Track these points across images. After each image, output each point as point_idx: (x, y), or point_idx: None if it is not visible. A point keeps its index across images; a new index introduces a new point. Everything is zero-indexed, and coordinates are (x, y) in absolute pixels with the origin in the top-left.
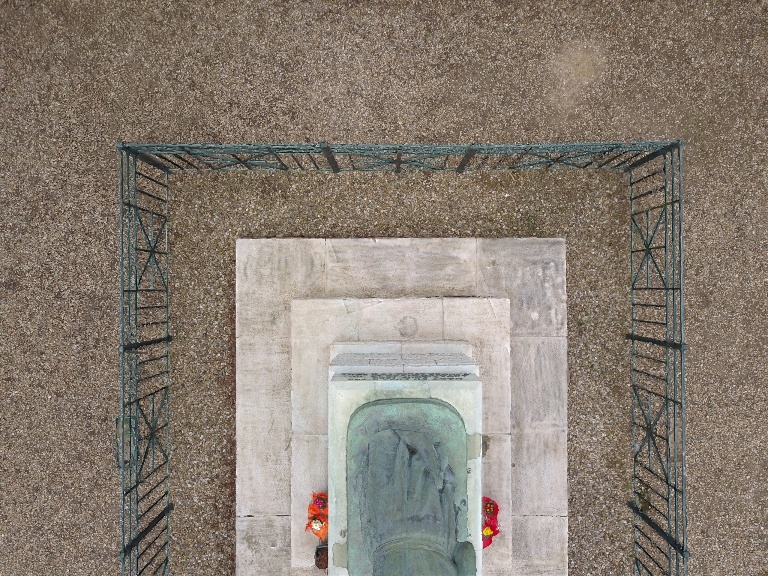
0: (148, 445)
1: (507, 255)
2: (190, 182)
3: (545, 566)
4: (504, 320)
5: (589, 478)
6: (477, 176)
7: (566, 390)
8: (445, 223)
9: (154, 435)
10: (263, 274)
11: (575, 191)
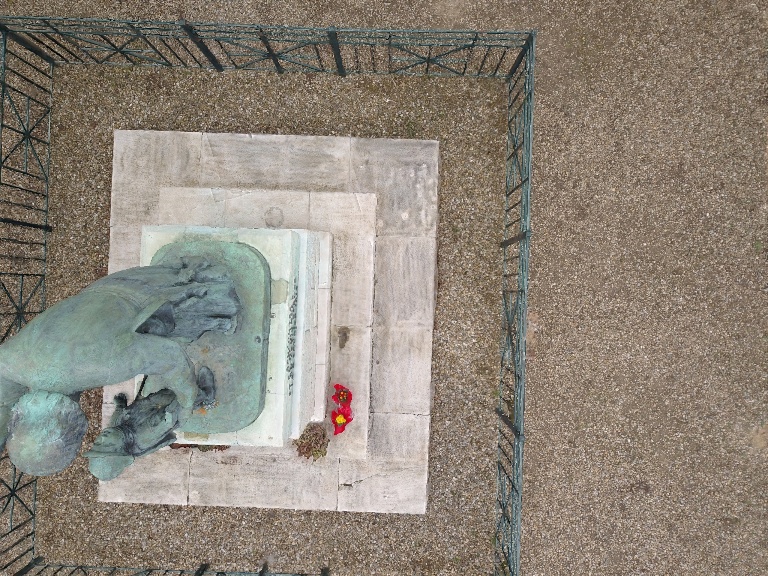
0: (12, 323)
1: (380, 155)
2: (76, 76)
3: (405, 463)
4: (369, 214)
5: (458, 383)
6: (360, 81)
7: (433, 290)
8: (326, 125)
9: (21, 316)
10: (139, 165)
11: (456, 99)
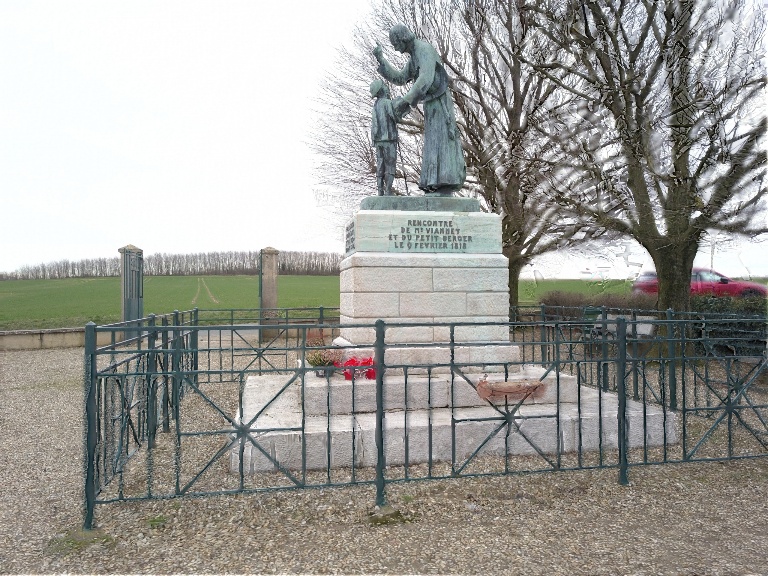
0: None
1: None
2: None
3: None
4: None
5: None
6: None
7: None
8: None
9: None
10: None
11: None
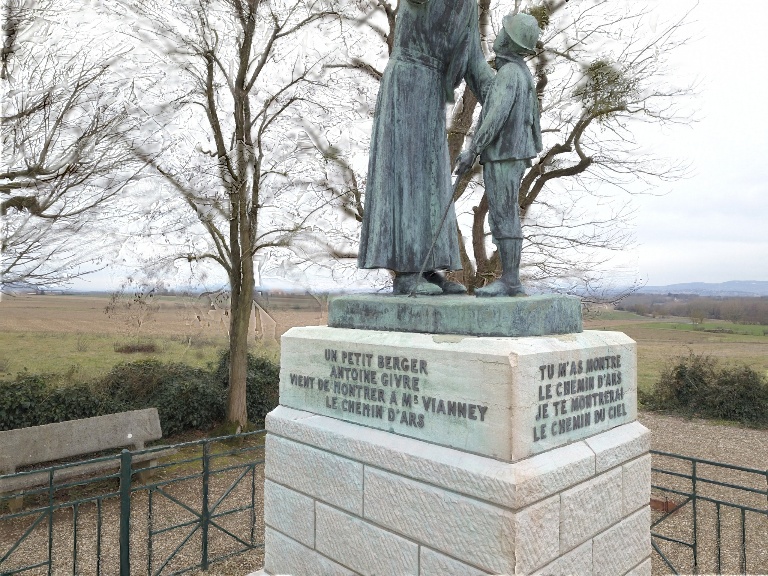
0: None
1: None
2: None
3: None
4: None
5: None
6: None
7: None
8: None
9: None
10: None
11: None
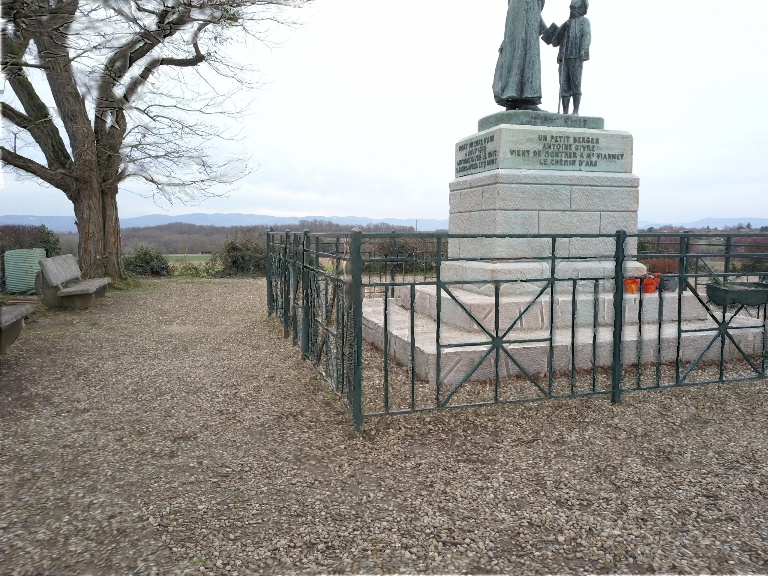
0: None
1: None
2: None
3: None
4: None
5: None
6: None
7: None
8: None
9: (725, 331)
10: None
11: None
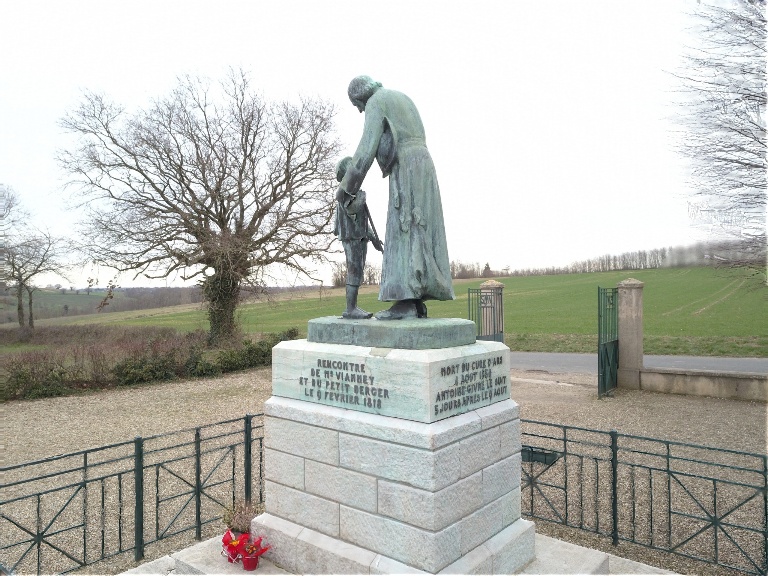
0: None
1: None
2: None
3: None
4: None
5: None
6: None
7: None
8: None
9: (530, 482)
10: None
11: None
